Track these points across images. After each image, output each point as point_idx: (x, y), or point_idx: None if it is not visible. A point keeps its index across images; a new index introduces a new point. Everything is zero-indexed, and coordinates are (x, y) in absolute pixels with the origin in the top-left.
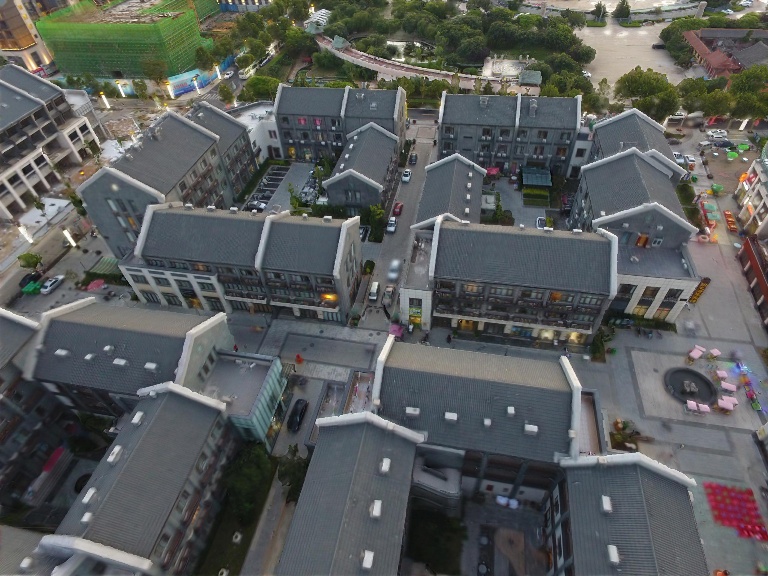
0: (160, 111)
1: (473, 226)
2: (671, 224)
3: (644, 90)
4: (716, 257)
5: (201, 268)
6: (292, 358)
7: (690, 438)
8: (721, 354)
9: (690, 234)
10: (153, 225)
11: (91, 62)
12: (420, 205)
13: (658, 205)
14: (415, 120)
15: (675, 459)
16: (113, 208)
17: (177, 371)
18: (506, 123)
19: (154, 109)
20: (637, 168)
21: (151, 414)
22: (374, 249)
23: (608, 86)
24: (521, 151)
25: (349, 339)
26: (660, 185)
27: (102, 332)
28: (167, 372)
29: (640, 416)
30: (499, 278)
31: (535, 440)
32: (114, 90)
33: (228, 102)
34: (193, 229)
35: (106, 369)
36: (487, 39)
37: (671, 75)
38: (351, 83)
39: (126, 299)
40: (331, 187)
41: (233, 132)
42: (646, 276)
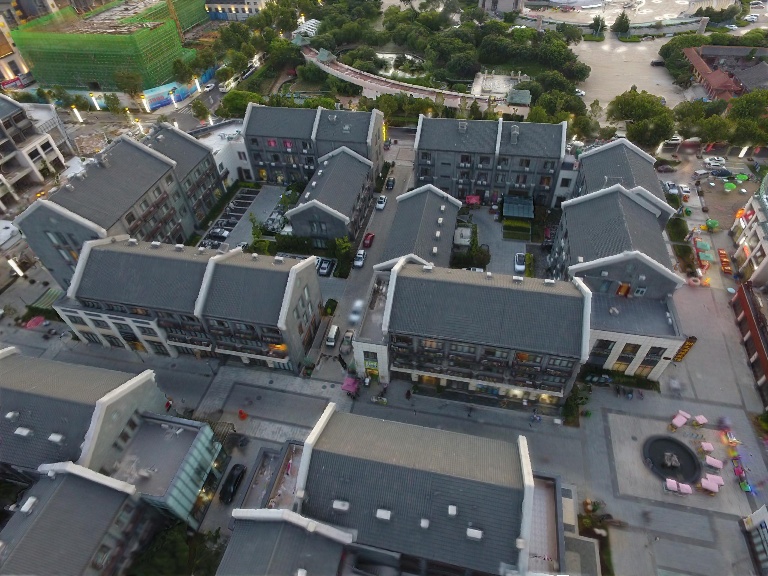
0: (134, 126)
1: (436, 272)
2: (655, 274)
3: (637, 113)
4: (708, 303)
5: (140, 311)
6: (235, 413)
7: (668, 524)
8: (708, 420)
9: (676, 285)
10: (90, 263)
11: (67, 73)
12: (387, 241)
13: (640, 254)
14: (396, 140)
15: (650, 550)
16: (54, 241)
17: (83, 446)
18: (486, 150)
19: (128, 123)
20: (620, 208)
21: (43, 501)
22: (338, 286)
23: (600, 108)
24: (502, 179)
25: (300, 392)
26: (645, 227)
27: (7, 395)
28: (74, 445)
29: (613, 495)
30: (459, 335)
31: (479, 547)
32: (86, 104)
33: (202, 118)
34: (132, 269)
35: (8, 438)
36: (479, 53)
37: (669, 95)
38: (333, 99)
39: (67, 338)
40: (295, 218)
41: (195, 155)
42: (625, 333)
